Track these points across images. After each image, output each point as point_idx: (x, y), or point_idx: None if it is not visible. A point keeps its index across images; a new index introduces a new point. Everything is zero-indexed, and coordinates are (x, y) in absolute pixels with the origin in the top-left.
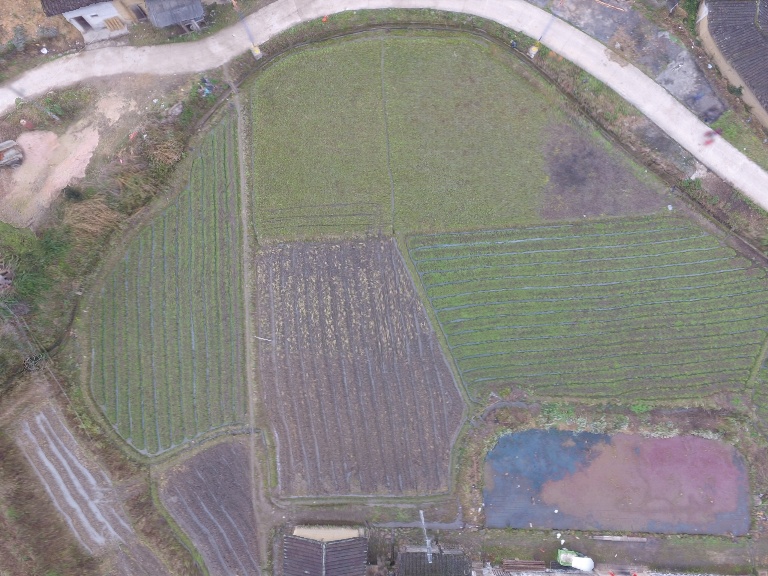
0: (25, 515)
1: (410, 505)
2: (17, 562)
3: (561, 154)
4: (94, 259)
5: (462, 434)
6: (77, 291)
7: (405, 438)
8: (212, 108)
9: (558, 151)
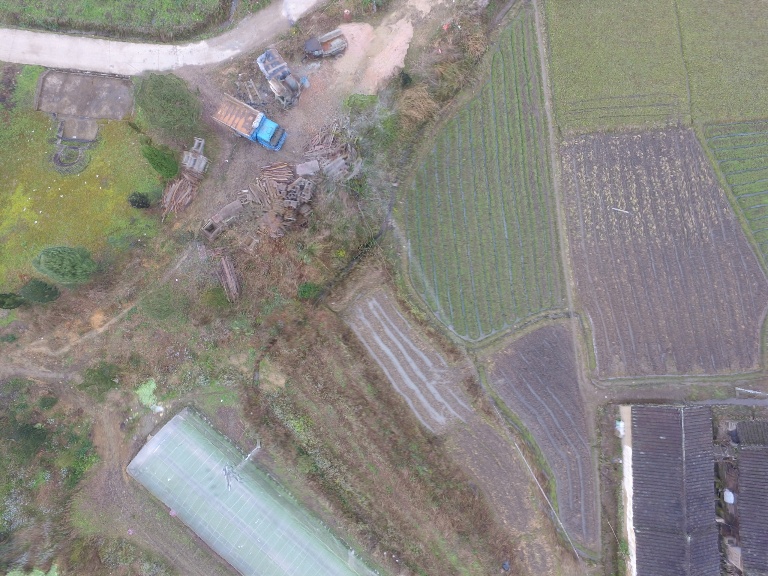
0: (379, 393)
1: (725, 383)
2: (379, 436)
3: None
4: (408, 151)
5: None
6: (393, 183)
7: (715, 319)
8: (509, 3)
9: None
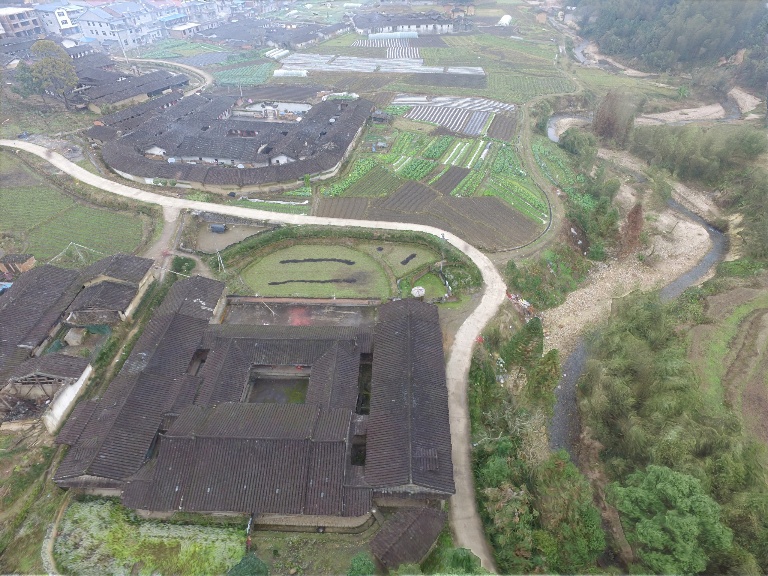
0: None
1: None
2: None
3: None
4: None
5: None
6: None
7: None
8: None
9: (6, 173)
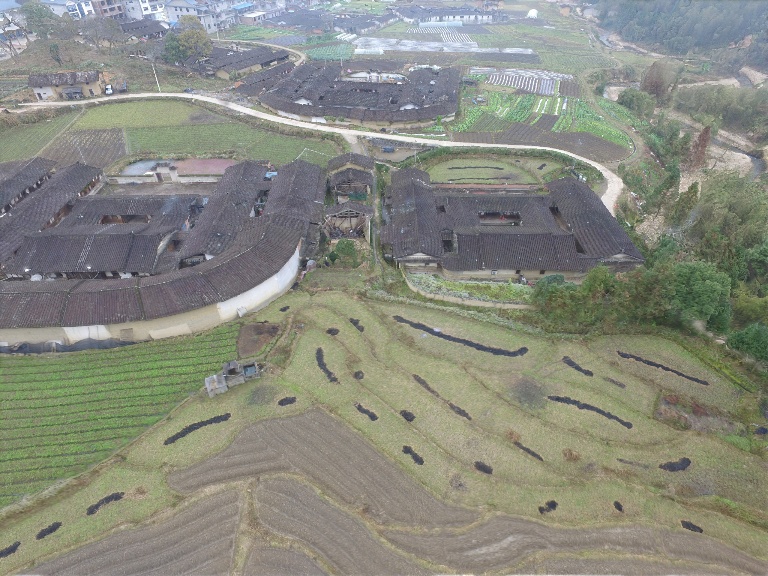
0: None
1: None
2: None
3: (195, 115)
4: None
5: None
6: None
7: None
8: None
9: None
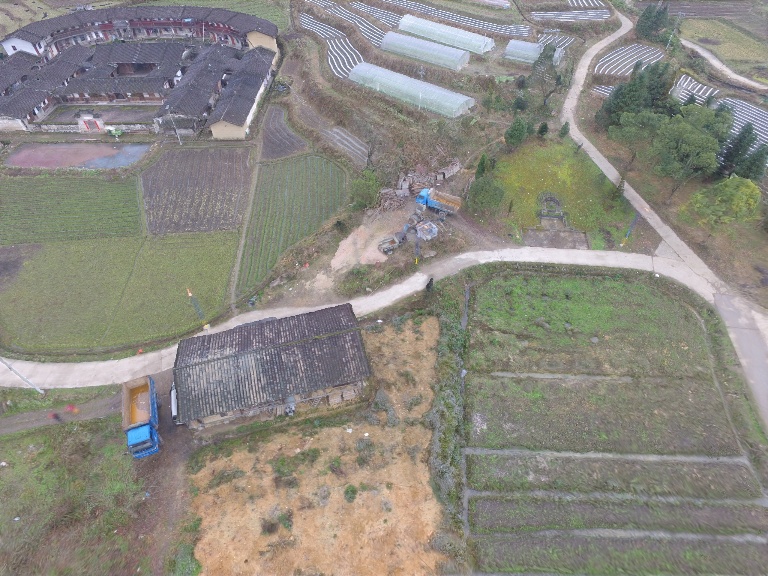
0: (364, 129)
1: None
2: (365, 116)
3: (4, 277)
4: None
5: (148, 166)
6: None
7: None
8: None
9: (5, 279)
